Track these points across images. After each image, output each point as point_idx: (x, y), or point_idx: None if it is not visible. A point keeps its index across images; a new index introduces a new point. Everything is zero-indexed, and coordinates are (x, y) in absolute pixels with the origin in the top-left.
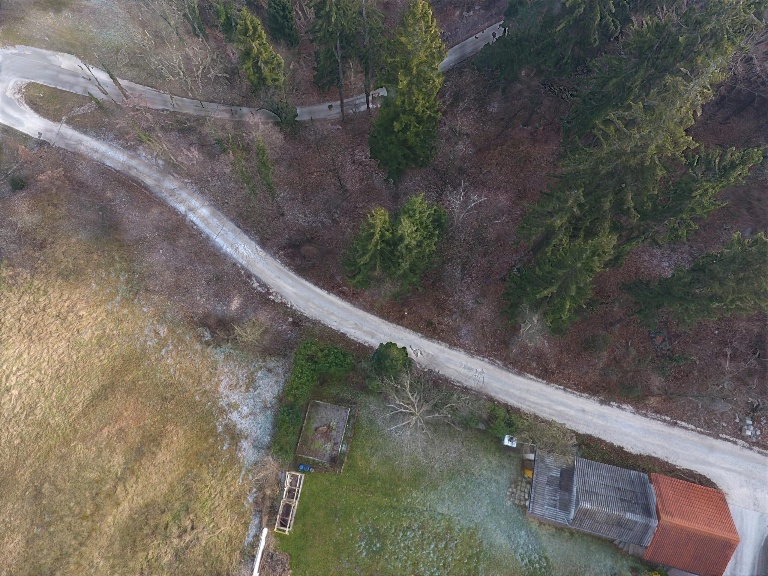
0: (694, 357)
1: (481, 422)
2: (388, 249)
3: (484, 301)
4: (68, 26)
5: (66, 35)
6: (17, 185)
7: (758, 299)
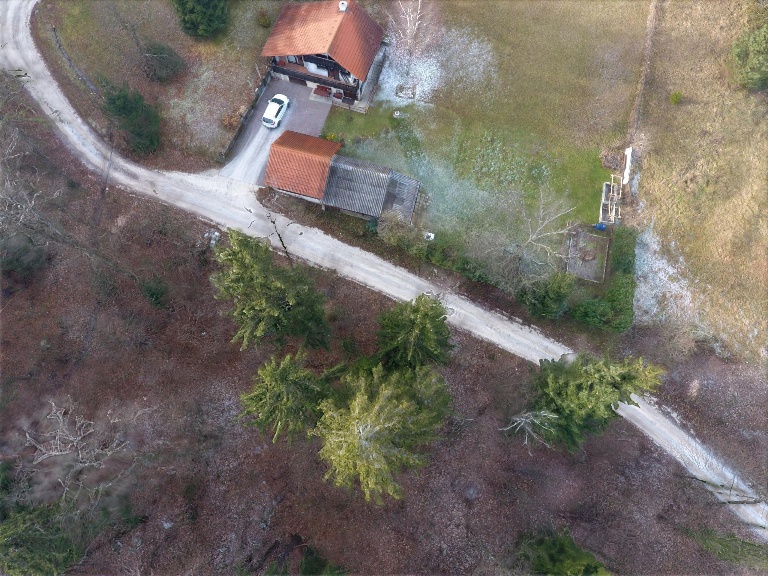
0: None
1: None
2: None
3: None
4: None
5: None
6: None
7: None
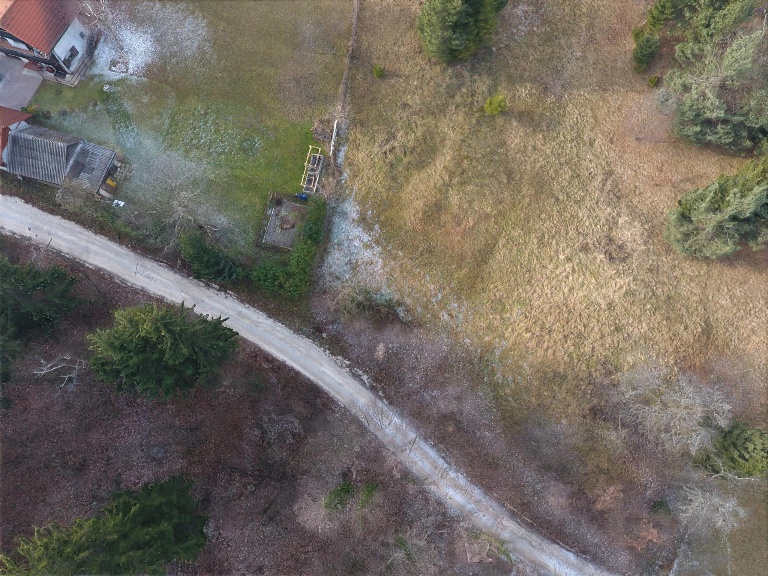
0: None
1: None
2: None
3: None
4: None
5: None
6: (660, 505)
7: None
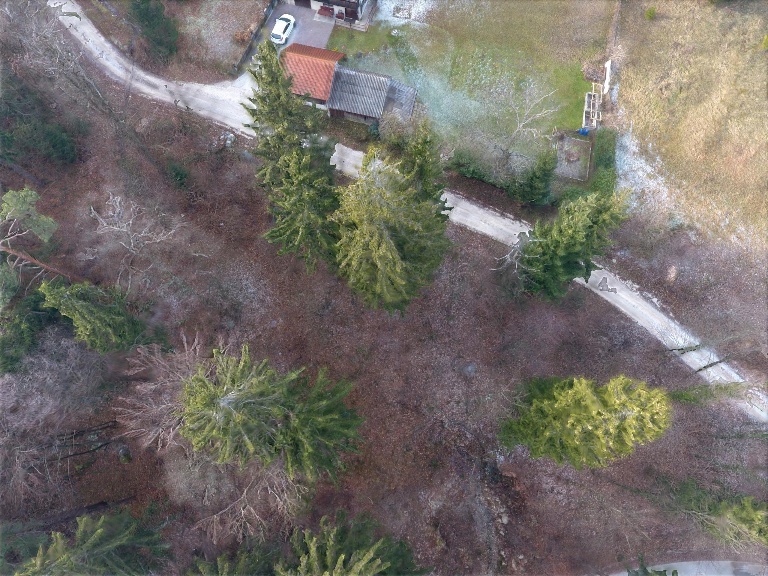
0: None
1: None
2: None
3: None
4: None
5: None
6: None
7: None
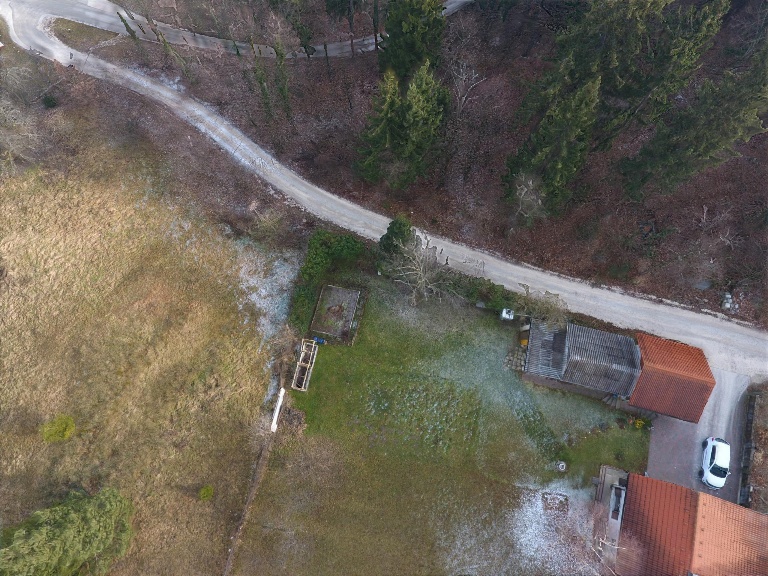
0: (676, 227)
1: (481, 299)
2: (397, 122)
3: (485, 203)
4: None
5: None
6: (50, 102)
7: (727, 138)
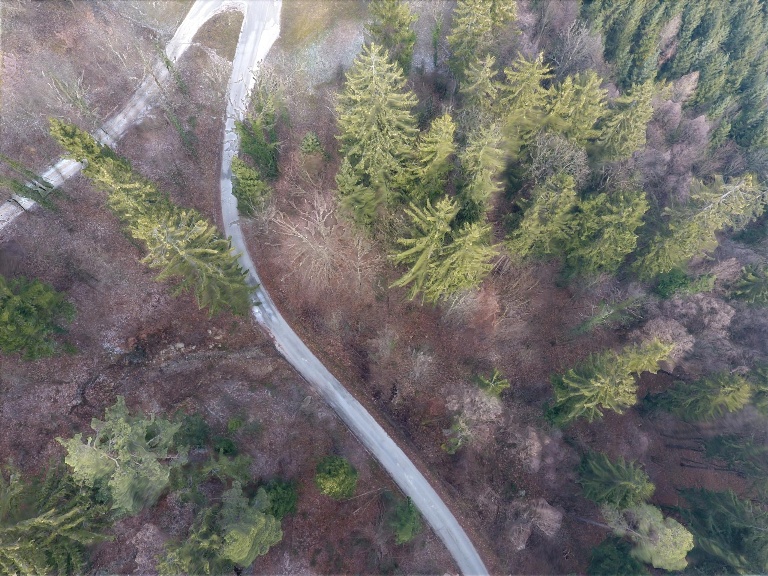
0: None
1: None
2: None
3: None
4: (319, 25)
5: (306, 26)
6: None
7: None
